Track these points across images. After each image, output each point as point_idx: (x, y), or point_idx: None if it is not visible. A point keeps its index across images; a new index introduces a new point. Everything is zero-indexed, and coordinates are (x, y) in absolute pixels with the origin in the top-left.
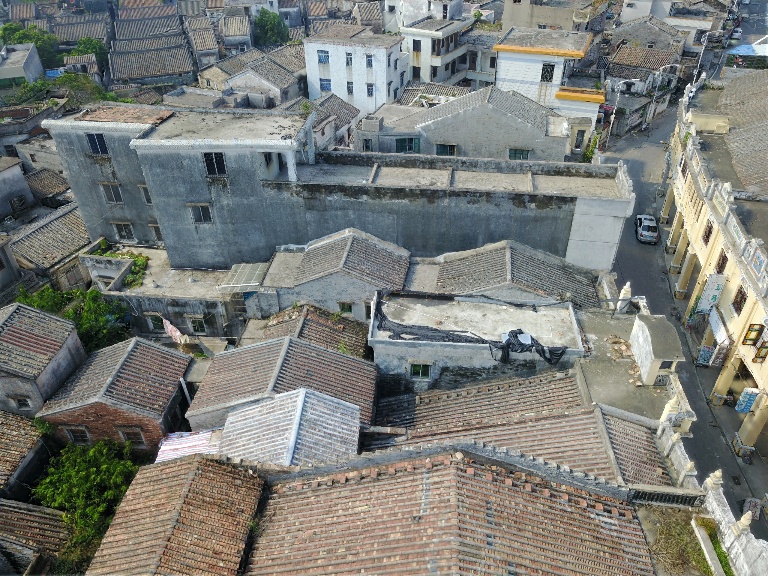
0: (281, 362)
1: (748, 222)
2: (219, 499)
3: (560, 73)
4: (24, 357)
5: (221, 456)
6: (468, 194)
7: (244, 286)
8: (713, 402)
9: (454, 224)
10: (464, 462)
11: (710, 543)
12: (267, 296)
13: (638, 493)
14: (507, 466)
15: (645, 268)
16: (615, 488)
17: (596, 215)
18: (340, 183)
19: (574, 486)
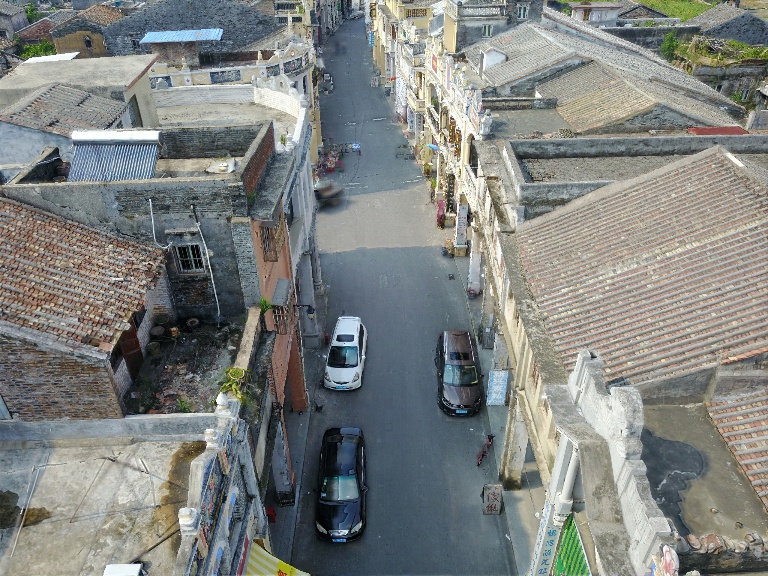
0: (135, 6)
1: None
2: None
3: None
4: (3, 10)
5: None
6: None
7: (116, 1)
8: (375, 65)
9: None
10: None
11: None
12: (129, 4)
13: (278, 5)
14: None
15: (365, 41)
16: None
17: None
18: None
19: (251, 1)
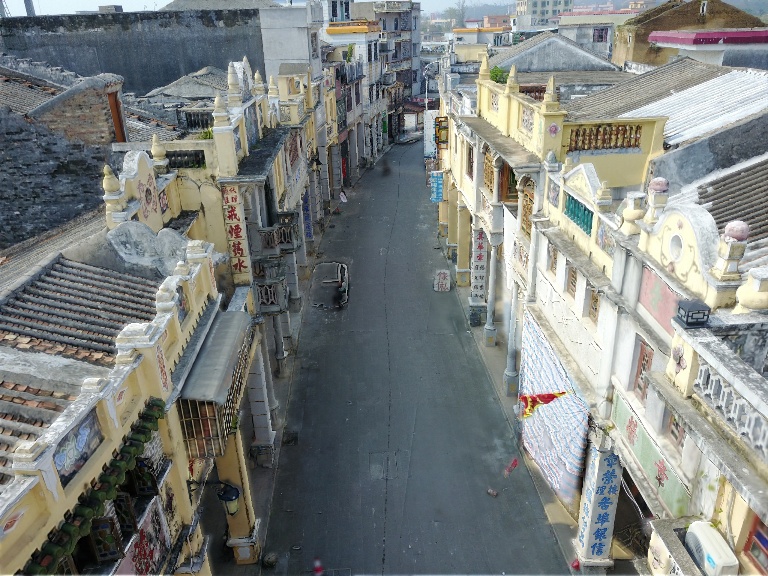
0: None
1: (467, 78)
2: None
3: (326, 9)
4: None
5: None
6: (158, 16)
7: None
8: (441, 233)
9: (153, 53)
10: None
11: None
12: None
13: (190, 118)
14: (35, 81)
15: (423, 180)
16: (160, 107)
17: (281, 28)
18: (34, 15)
19: None
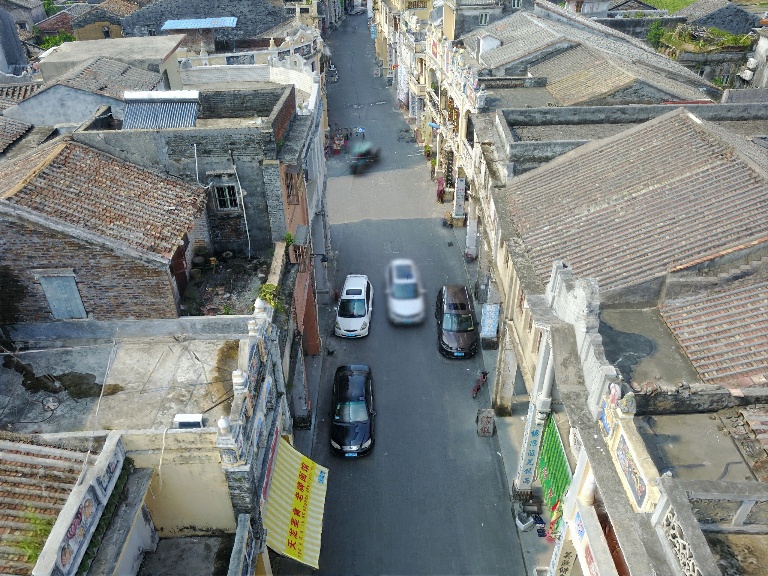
0: None
1: None
2: (124, 4)
3: None
4: (23, 3)
5: None
6: None
7: None
8: (377, 58)
9: None
10: None
11: (305, 0)
12: None
13: None
14: None
15: (368, 35)
16: None
17: None
18: None
19: None
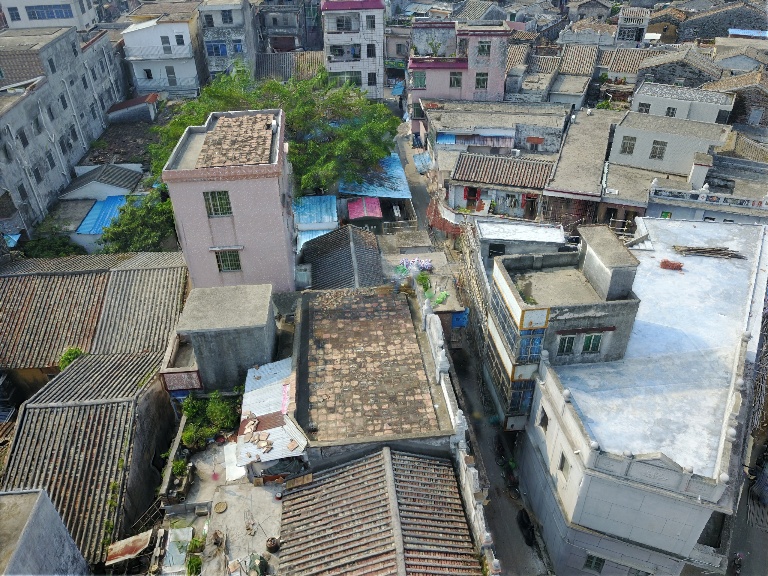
0: None
1: None
2: None
3: None
4: (605, 4)
5: (677, 8)
6: None
7: (664, 4)
8: None
9: None
10: (744, 4)
11: None
12: (672, 7)
13: None
14: None
15: None
16: None
17: None
18: None
19: None
